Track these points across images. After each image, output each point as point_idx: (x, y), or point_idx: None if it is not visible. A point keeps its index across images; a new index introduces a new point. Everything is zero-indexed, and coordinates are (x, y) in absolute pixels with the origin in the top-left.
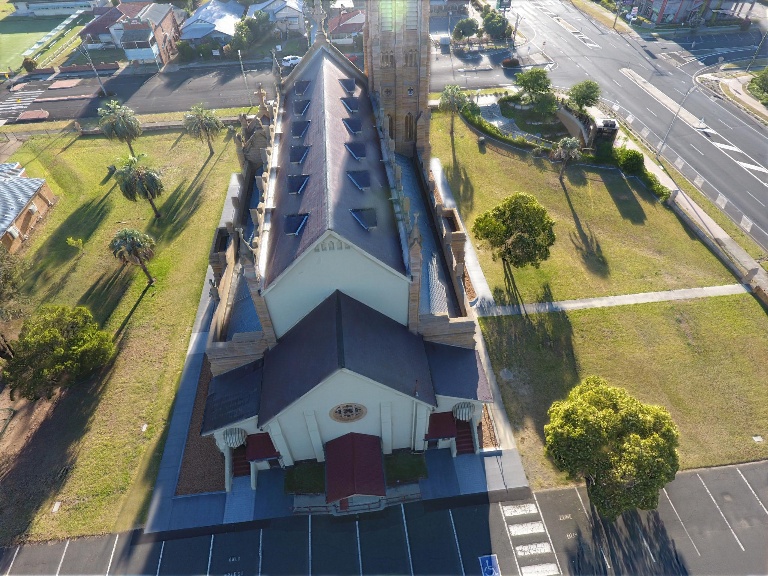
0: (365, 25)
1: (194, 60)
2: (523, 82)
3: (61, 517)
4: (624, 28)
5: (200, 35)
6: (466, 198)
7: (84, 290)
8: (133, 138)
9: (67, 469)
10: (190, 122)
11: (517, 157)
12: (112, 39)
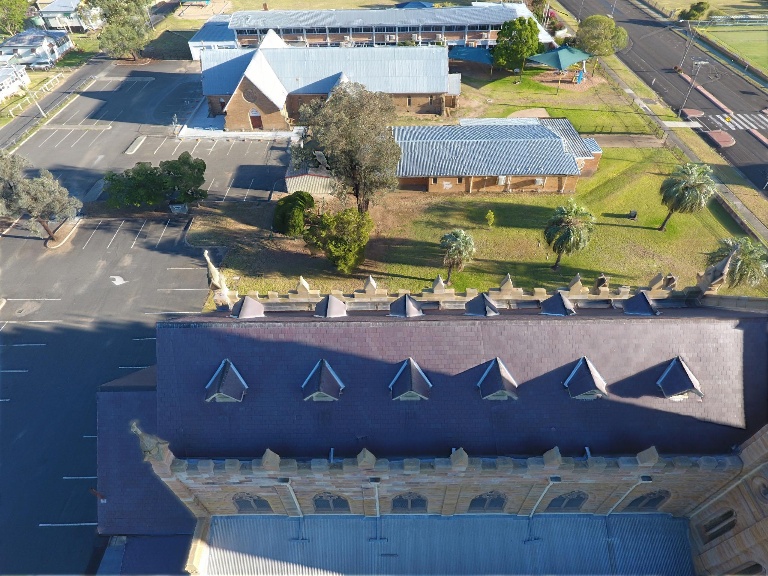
0: None
1: None
2: None
3: (228, 281)
4: None
5: None
6: None
7: (439, 242)
8: (673, 209)
9: (262, 276)
10: (727, 248)
11: None
12: None
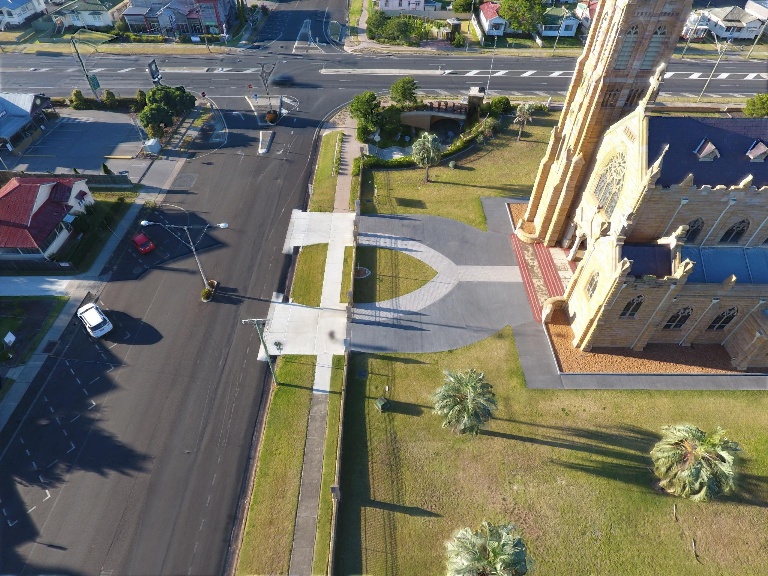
0: None
1: None
2: (370, 111)
3: None
4: (218, 49)
5: None
6: None
7: None
8: None
9: None
10: None
11: (483, 153)
12: None
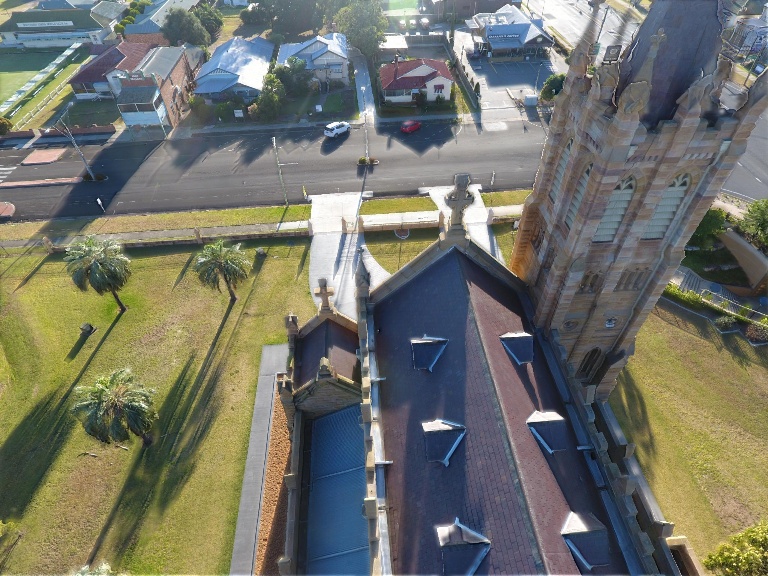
0: (533, 200)
1: (211, 121)
2: None
3: None
4: None
5: (219, 88)
6: (638, 423)
7: None
8: (118, 288)
9: None
10: (203, 265)
11: (694, 329)
12: (110, 88)
